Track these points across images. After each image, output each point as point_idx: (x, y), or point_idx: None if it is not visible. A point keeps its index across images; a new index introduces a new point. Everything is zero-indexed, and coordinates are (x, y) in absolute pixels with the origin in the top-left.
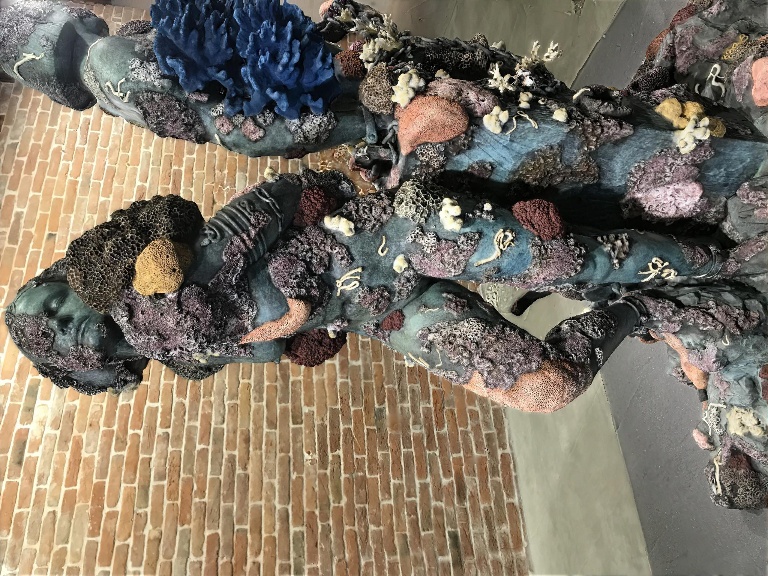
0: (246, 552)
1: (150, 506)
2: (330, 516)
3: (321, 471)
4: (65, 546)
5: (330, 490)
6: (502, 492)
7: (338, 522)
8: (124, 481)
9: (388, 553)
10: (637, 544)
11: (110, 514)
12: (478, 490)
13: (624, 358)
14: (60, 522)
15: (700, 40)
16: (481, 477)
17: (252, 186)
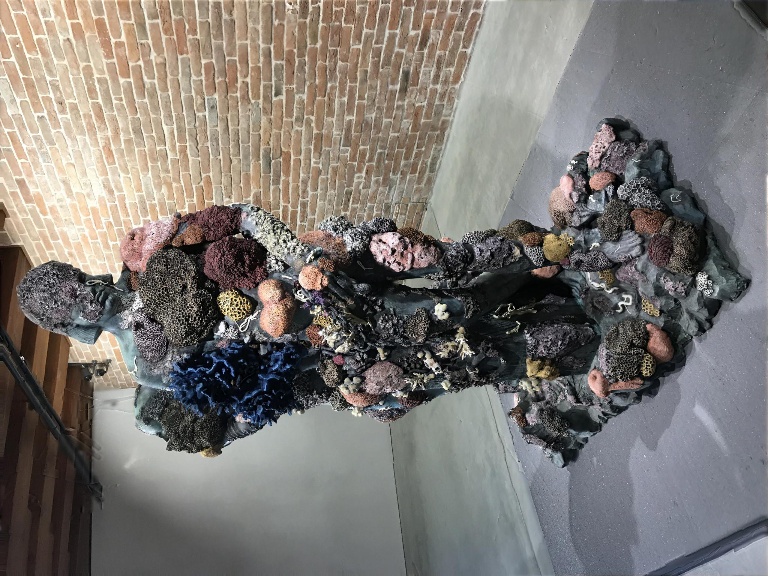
0: (236, 75)
1: (151, 41)
2: (306, 55)
3: (301, 20)
4: (89, 64)
5: (308, 36)
6: (460, 43)
7: (312, 58)
8: (121, 18)
9: (350, 79)
10: (502, 204)
11: (118, 44)
12: (439, 41)
13: (534, 190)
14: (77, 48)
15: (640, 285)
16: (446, 30)
17: (249, 421)
